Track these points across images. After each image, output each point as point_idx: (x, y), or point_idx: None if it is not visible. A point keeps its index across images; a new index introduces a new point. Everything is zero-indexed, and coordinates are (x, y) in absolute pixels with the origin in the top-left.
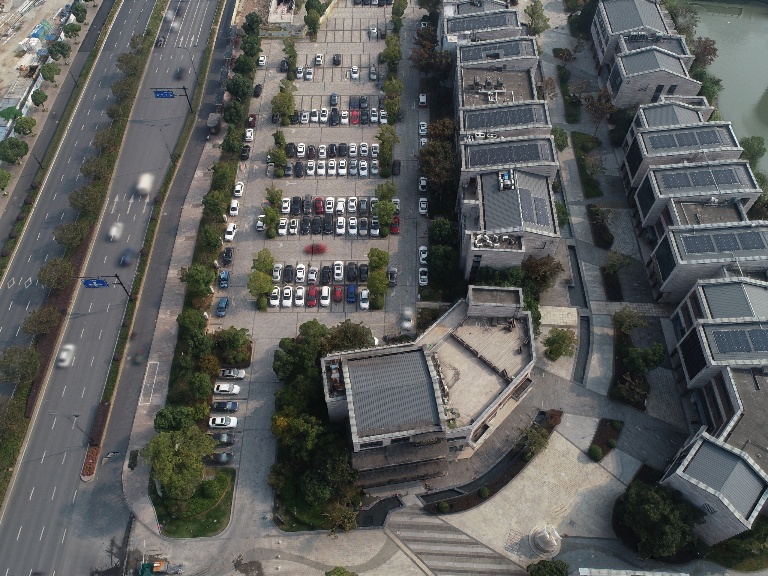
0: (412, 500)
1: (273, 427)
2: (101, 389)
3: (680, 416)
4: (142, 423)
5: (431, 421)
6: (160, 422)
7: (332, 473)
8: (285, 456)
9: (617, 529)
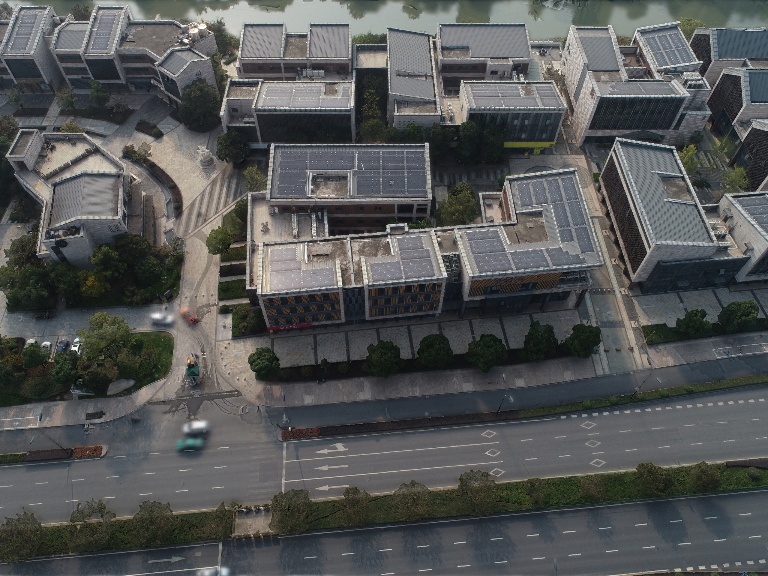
0: (170, 224)
1: (93, 291)
2: (7, 469)
3: (143, 97)
4: (59, 418)
5: (115, 179)
6: (66, 367)
7: (140, 245)
8: (119, 298)
9: (205, 130)
